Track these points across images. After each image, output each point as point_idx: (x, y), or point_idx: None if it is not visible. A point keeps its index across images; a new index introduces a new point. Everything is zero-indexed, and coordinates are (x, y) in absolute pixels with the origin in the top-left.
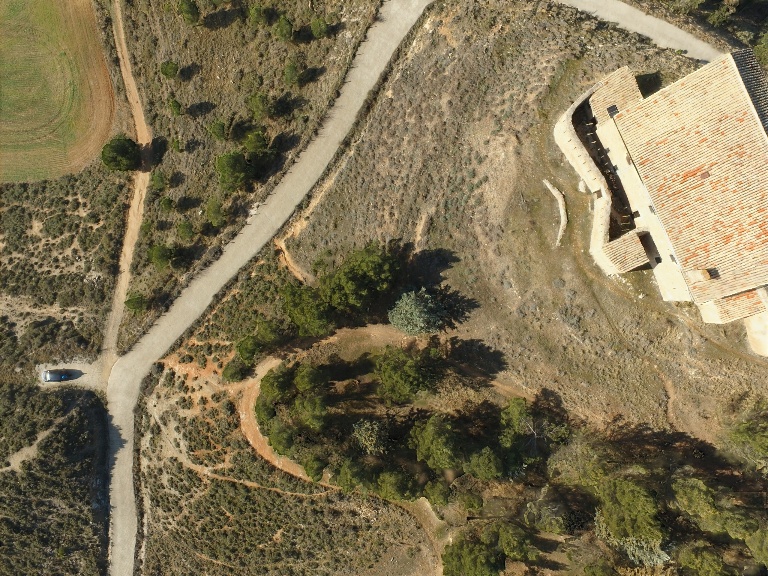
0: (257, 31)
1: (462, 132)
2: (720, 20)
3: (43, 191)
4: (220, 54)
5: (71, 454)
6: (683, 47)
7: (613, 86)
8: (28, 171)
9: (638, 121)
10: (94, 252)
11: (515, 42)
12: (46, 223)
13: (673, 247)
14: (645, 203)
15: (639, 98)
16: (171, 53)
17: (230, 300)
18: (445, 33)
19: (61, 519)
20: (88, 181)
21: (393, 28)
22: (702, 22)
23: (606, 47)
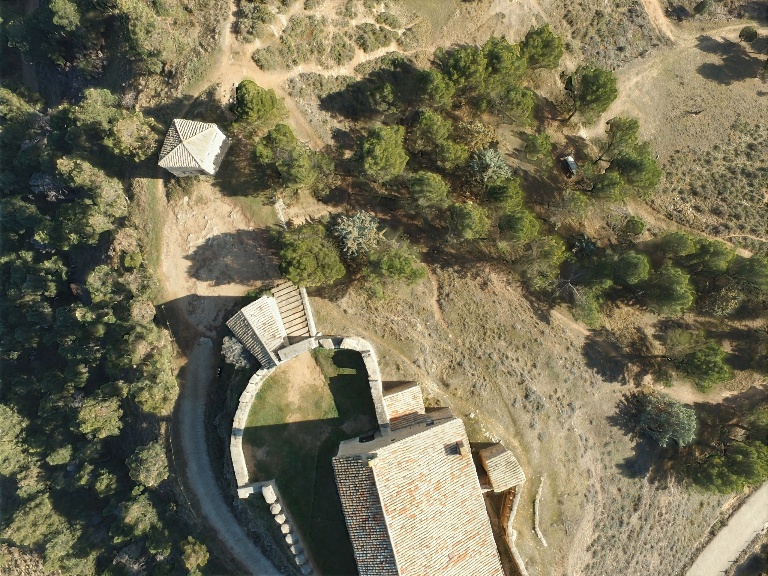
0: None
1: None
2: None
3: None
4: None
5: None
6: None
7: None
8: None
9: None
10: None
11: None
12: None
13: (477, 479)
14: None
15: None
16: None
17: None
18: None
19: None
20: None
21: None
22: None
23: None
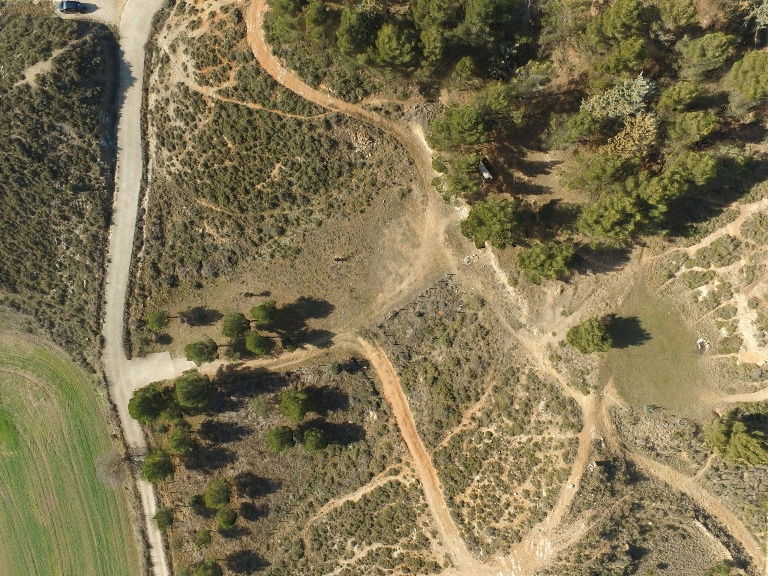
0: None
1: None
2: None
3: None
4: None
5: (83, 75)
6: None
7: None
8: None
9: None
10: None
11: None
12: None
13: None
14: None
15: None
16: None
17: None
18: None
19: (71, 151)
20: None
21: None
22: None
23: None
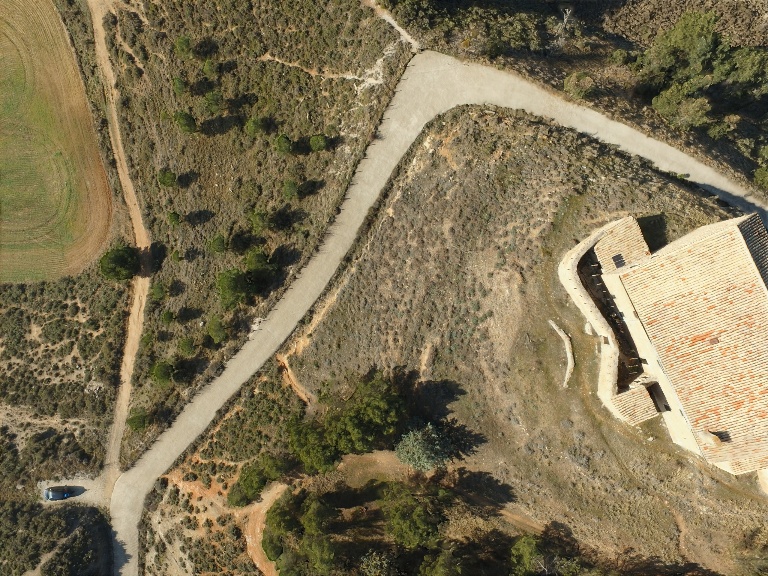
0: (255, 139)
1: (465, 261)
2: (721, 134)
3: (41, 293)
4: (218, 161)
5: (75, 575)
6: (685, 171)
7: (618, 235)
8: (26, 272)
9: (645, 282)
10: (94, 361)
11: (516, 169)
12: (45, 329)
13: (683, 407)
14: (653, 357)
15: (644, 248)
16: (168, 159)
17: (233, 418)
18: (445, 154)
19: None
20: (87, 284)
21: (393, 146)
22: (703, 135)
23: (609, 181)
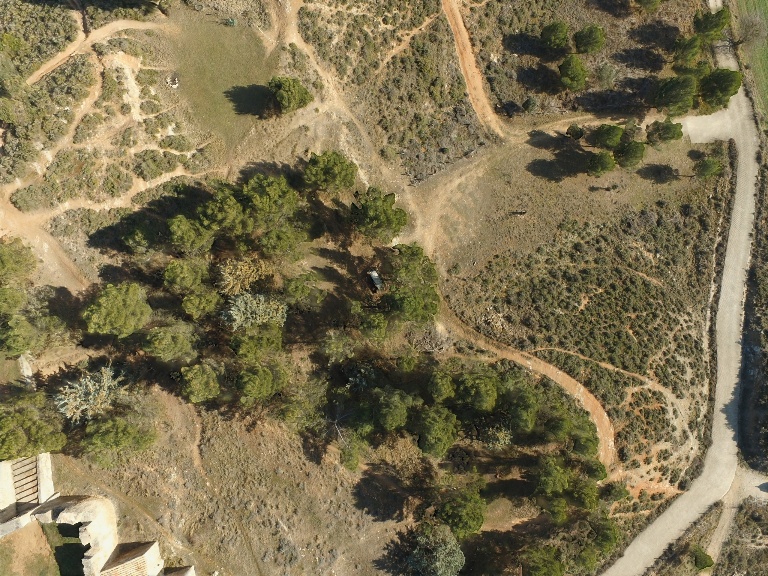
0: None
1: None
2: None
3: None
4: None
5: None
6: None
7: None
8: None
9: None
10: None
11: None
12: None
13: None
14: None
15: None
16: None
17: None
18: None
19: None
20: None
21: None
22: None
23: None
